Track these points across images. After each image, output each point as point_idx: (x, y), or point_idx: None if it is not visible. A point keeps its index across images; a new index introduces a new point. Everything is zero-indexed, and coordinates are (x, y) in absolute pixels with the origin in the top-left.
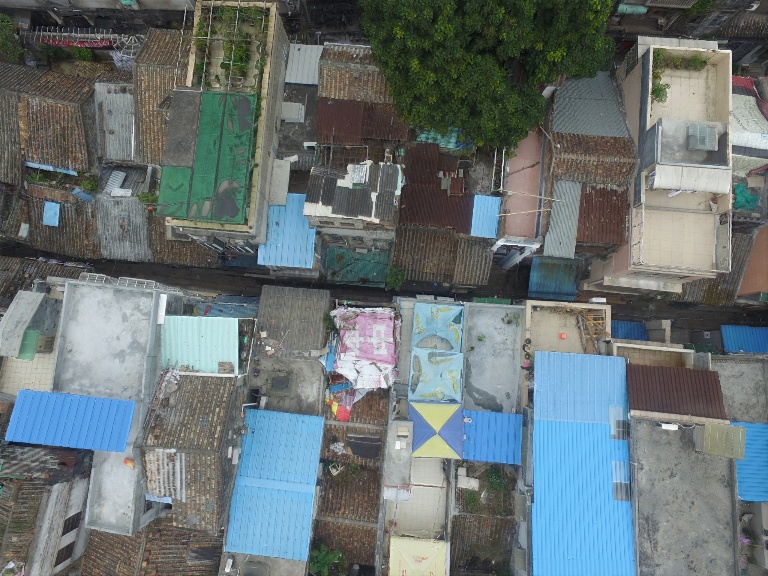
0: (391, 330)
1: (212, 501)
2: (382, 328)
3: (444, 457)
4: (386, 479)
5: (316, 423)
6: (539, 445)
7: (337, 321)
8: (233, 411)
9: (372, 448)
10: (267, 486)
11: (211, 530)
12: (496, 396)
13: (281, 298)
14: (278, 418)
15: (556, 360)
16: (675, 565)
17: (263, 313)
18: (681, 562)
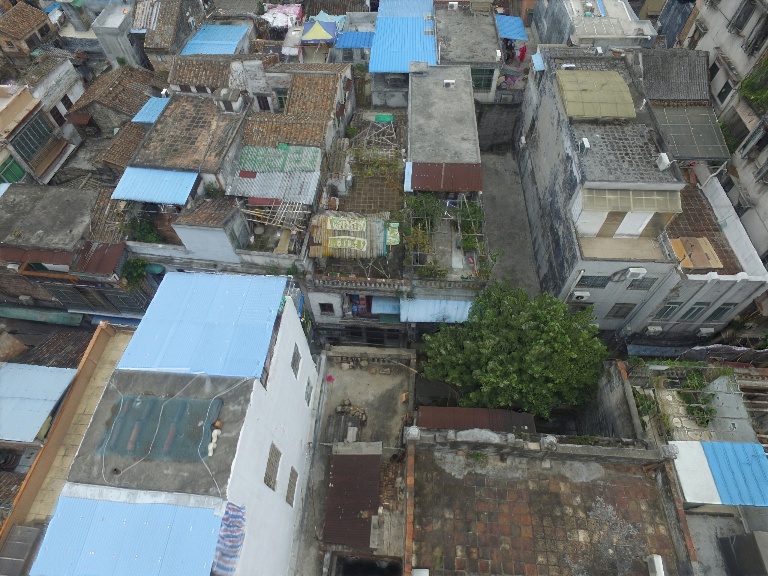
0: (298, 9)
1: (171, 28)
2: (292, 8)
3: (322, 39)
4: (284, 44)
5: (244, 27)
6: (379, 24)
7: (266, 8)
8: (194, 6)
9: (280, 53)
10: (207, 42)
11: (167, 47)
12: (366, 52)
13: (234, 0)
14: (221, 26)
15: (392, 2)
16: (461, 51)
17: (222, 4)
18: (465, 50)
